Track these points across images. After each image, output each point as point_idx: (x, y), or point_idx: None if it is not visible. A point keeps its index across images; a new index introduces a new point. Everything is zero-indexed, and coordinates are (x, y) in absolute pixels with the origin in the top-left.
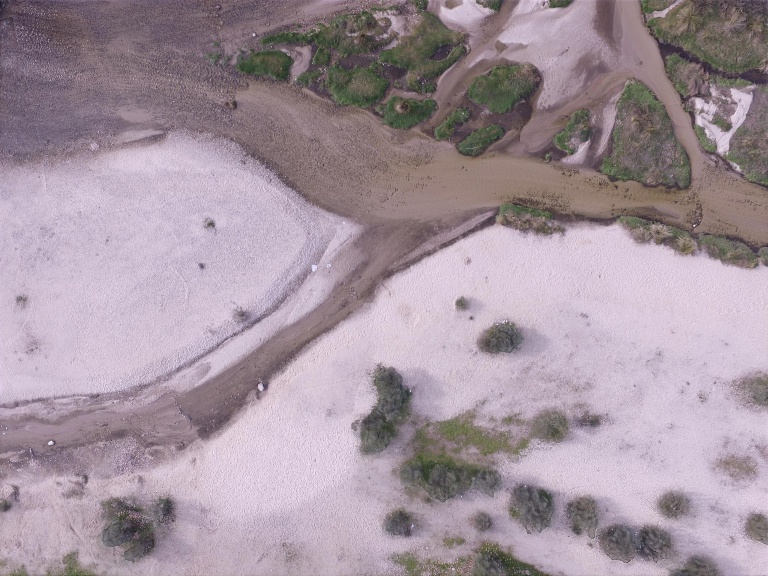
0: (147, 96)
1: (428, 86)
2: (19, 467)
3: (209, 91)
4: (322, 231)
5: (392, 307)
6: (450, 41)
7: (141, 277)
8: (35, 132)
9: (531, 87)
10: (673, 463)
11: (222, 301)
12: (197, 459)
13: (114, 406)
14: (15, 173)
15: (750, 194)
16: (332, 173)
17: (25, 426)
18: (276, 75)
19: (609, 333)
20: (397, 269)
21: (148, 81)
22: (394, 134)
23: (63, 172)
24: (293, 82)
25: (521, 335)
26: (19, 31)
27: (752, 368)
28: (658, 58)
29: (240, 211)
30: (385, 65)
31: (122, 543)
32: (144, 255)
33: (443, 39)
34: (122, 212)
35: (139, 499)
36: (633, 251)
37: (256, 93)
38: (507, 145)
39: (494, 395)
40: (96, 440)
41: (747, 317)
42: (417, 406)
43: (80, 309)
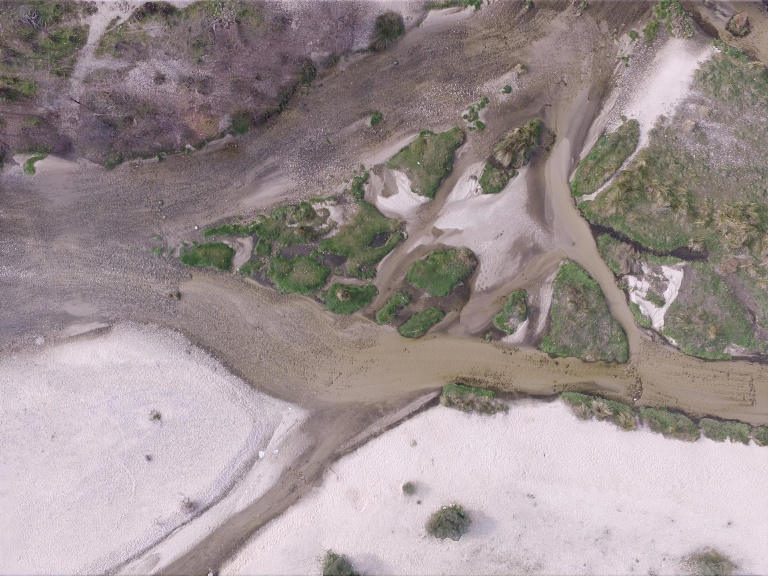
0: (92, 290)
1: (368, 272)
2: None
3: (153, 283)
4: (268, 418)
5: (340, 492)
6: (387, 229)
7: (87, 472)
8: None
9: (468, 271)
10: None
11: (169, 492)
12: None
13: None
14: None
15: (687, 366)
16: (276, 359)
17: None
18: (218, 267)
19: (556, 513)
20: (344, 452)
21: (93, 275)
22: (336, 319)
23: (9, 368)
24: (235, 272)
25: (469, 518)
26: None
27: (700, 544)
28: (590, 238)
29: (185, 402)
30: (325, 253)
31: None
32: (90, 450)
33: (380, 227)
34: (67, 407)
35: None
36: (576, 428)
37: (199, 284)
38: (448, 326)
39: None
40: None
41: (691, 493)
42: None
43: (26, 506)
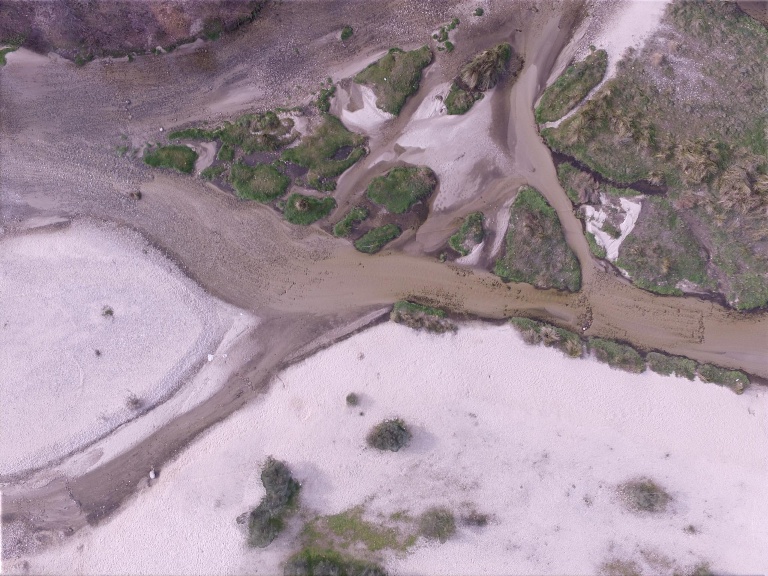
0: (54, 184)
1: (328, 185)
2: None
3: (115, 181)
4: (219, 322)
5: (285, 399)
6: (350, 143)
7: (37, 362)
8: None
9: (427, 190)
10: (559, 566)
11: (117, 388)
12: (85, 545)
13: (5, 489)
14: None
15: (639, 300)
16: (232, 265)
17: None
18: (180, 169)
19: (497, 434)
20: (292, 361)
21: (56, 170)
22: (293, 229)
23: None
24: (197, 176)
25: (410, 433)
26: None
27: (637, 474)
28: (551, 166)
29: (138, 300)
30: (287, 163)
31: None
32: (41, 340)
33: (343, 141)
34: (22, 297)
35: None
36: (523, 352)
37: (161, 185)
38: (403, 244)
39: (383, 491)
40: None
41: (632, 423)
42: (306, 499)
43: None
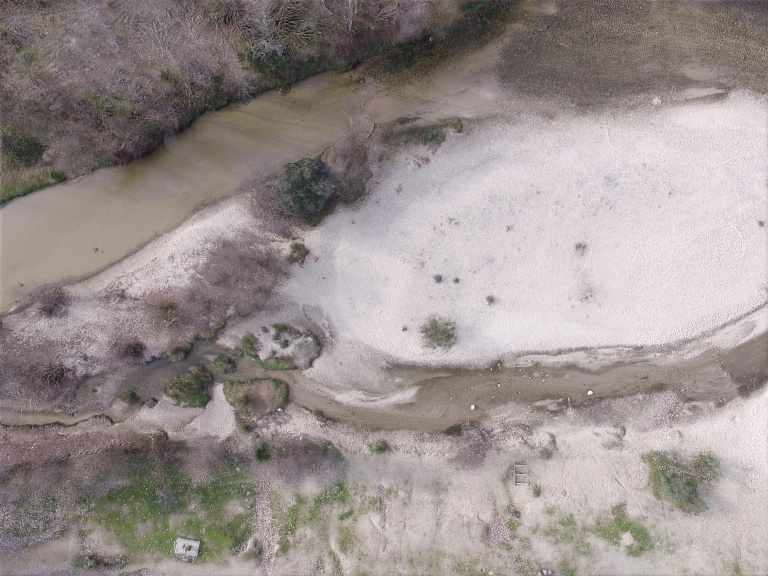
0: (711, 55)
1: None
2: (556, 415)
3: None
4: None
5: None
6: None
7: (701, 231)
8: (599, 84)
9: None
10: None
11: None
12: (736, 417)
13: (656, 359)
14: (577, 122)
15: None
16: None
17: (565, 374)
18: None
19: None
20: None
21: (713, 41)
22: None
23: (625, 124)
24: None
25: None
26: None
27: None
28: None
29: None
30: None
31: (669, 497)
32: (705, 210)
33: None
34: (686, 166)
35: (679, 454)
36: None
37: None
38: None
39: None
40: (635, 392)
41: None
42: None
43: (637, 260)
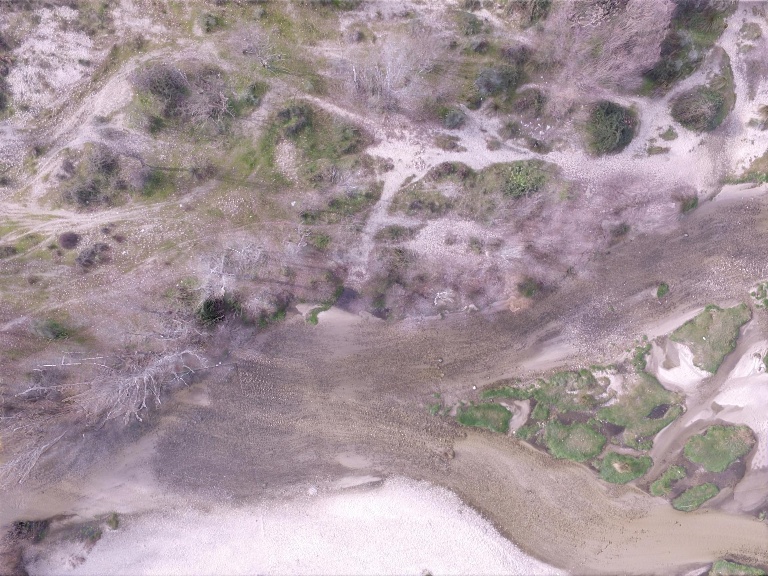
0: (366, 443)
1: (645, 444)
2: None
3: (427, 440)
4: None
5: None
6: (668, 402)
7: None
8: (254, 475)
9: (747, 450)
10: None
11: None
12: None
13: None
14: (232, 516)
15: None
16: (547, 524)
17: None
18: (496, 430)
19: None
20: None
21: (367, 428)
22: (609, 488)
23: (280, 516)
24: (511, 434)
25: None
26: (243, 377)
27: None
28: None
29: (457, 563)
30: (603, 422)
31: None
32: None
33: (661, 400)
34: (340, 561)
35: None
36: None
37: (474, 443)
38: (721, 502)
39: None
40: None
41: None
42: None
43: None
